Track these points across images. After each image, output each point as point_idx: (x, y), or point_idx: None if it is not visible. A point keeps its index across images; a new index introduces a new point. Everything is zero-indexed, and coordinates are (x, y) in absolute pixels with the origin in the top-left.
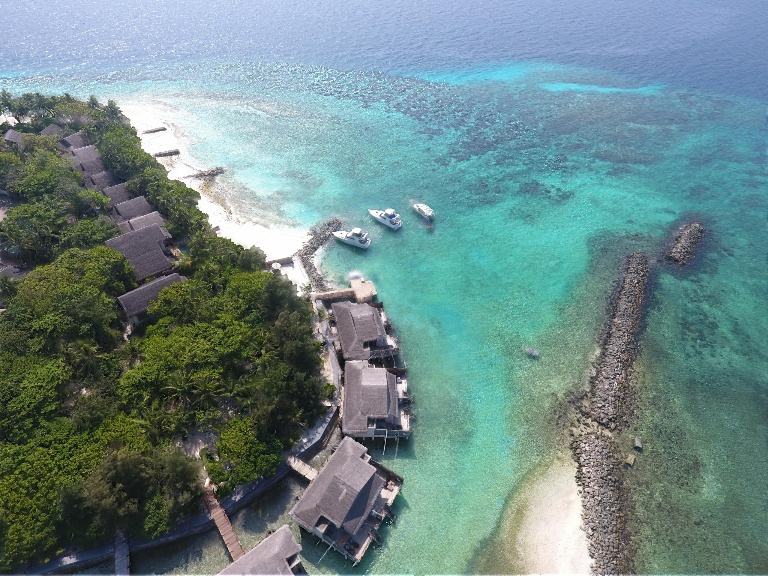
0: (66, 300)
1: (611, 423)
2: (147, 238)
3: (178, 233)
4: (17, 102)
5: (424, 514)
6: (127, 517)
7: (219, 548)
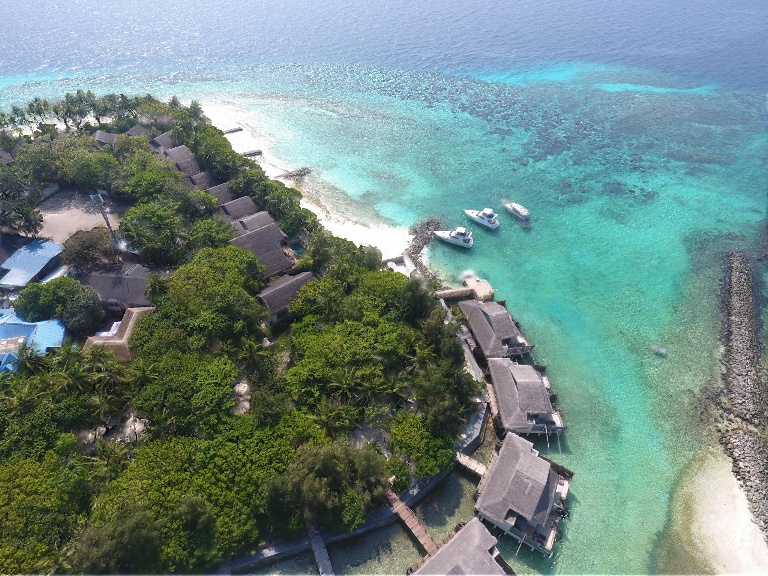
0: (219, 298)
1: (754, 419)
2: (268, 237)
3: (290, 233)
4: (100, 103)
5: (594, 508)
6: (329, 510)
7: (406, 541)
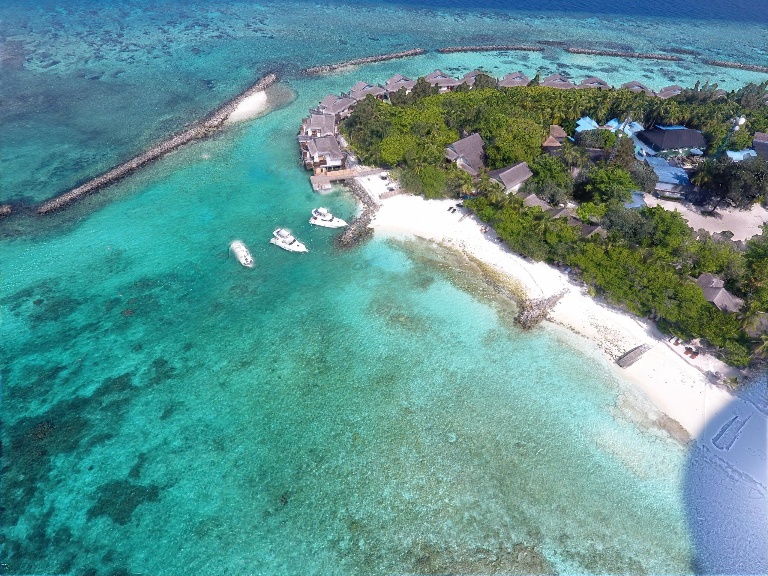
0: None
1: None
2: None
3: None
4: None
5: None
6: None
7: None
